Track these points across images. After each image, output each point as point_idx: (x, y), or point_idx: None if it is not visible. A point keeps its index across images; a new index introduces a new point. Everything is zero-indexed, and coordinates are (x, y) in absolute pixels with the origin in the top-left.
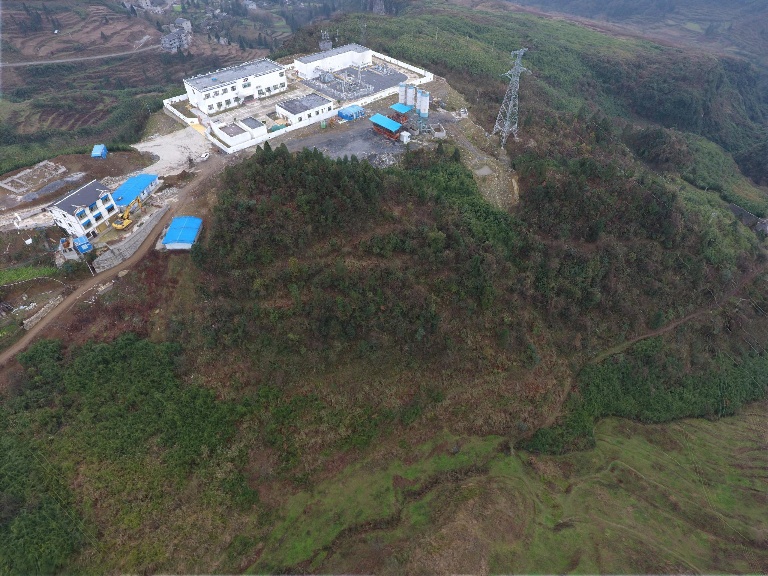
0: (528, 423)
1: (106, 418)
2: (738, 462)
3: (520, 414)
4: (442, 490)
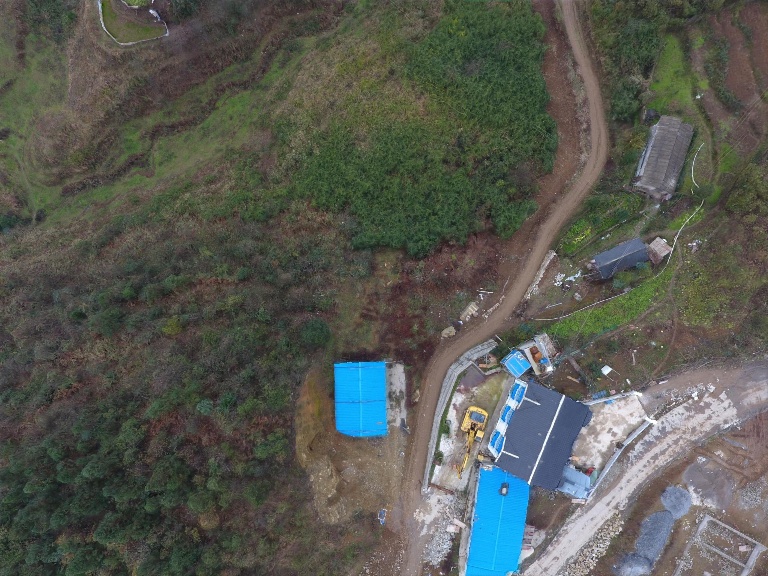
0: (2, 238)
1: (415, 157)
2: None
3: (3, 242)
4: (108, 166)
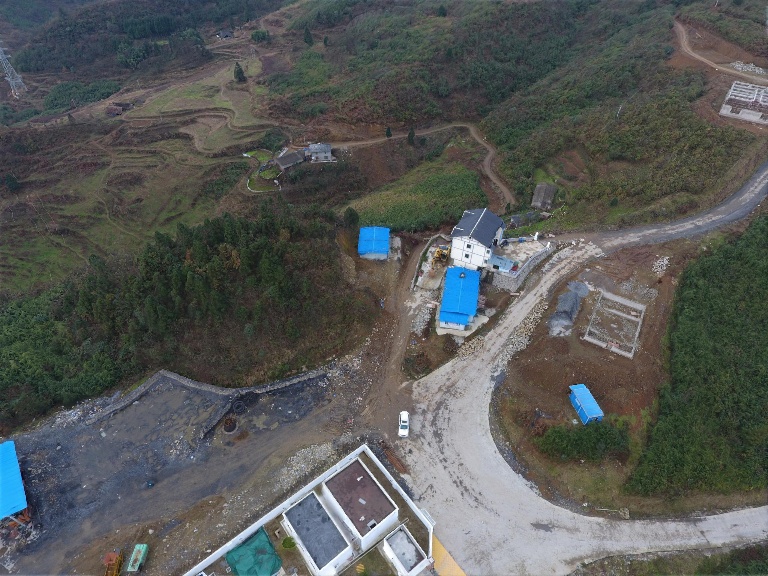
0: None
1: None
2: (6, 277)
3: None
4: None
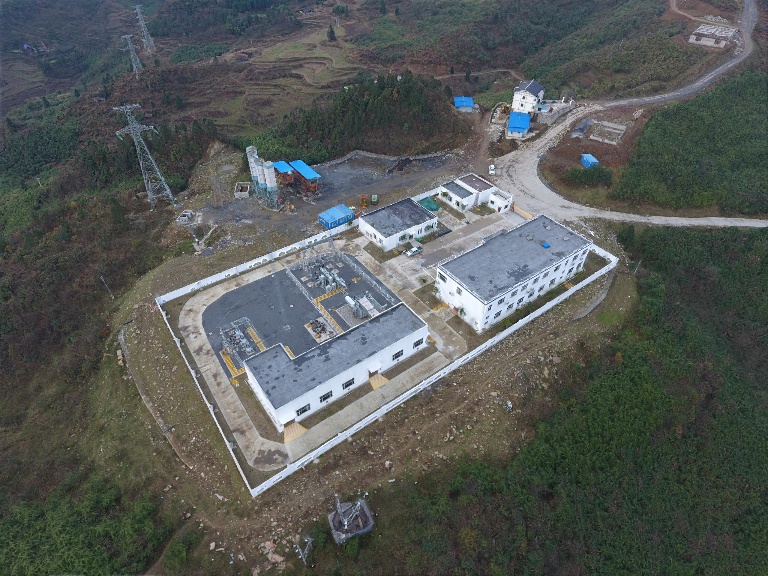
0: None
1: None
2: None
3: None
4: None
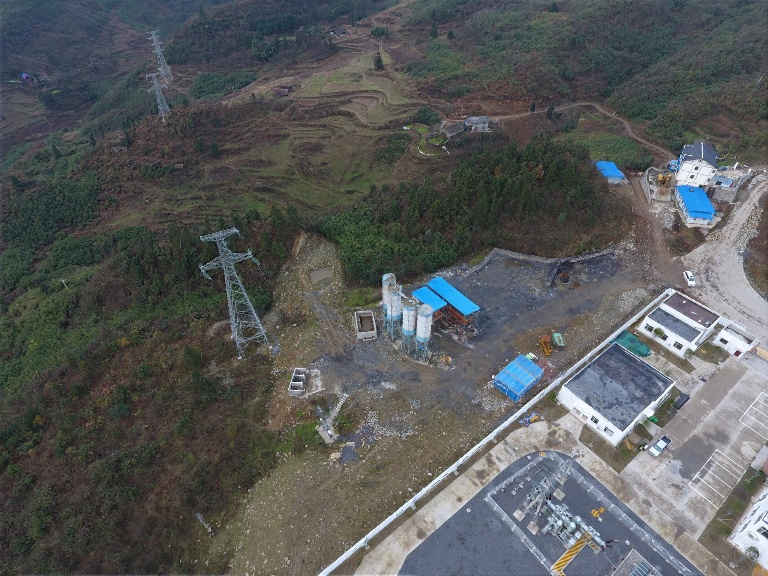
0: None
1: None
2: None
3: None
4: None
